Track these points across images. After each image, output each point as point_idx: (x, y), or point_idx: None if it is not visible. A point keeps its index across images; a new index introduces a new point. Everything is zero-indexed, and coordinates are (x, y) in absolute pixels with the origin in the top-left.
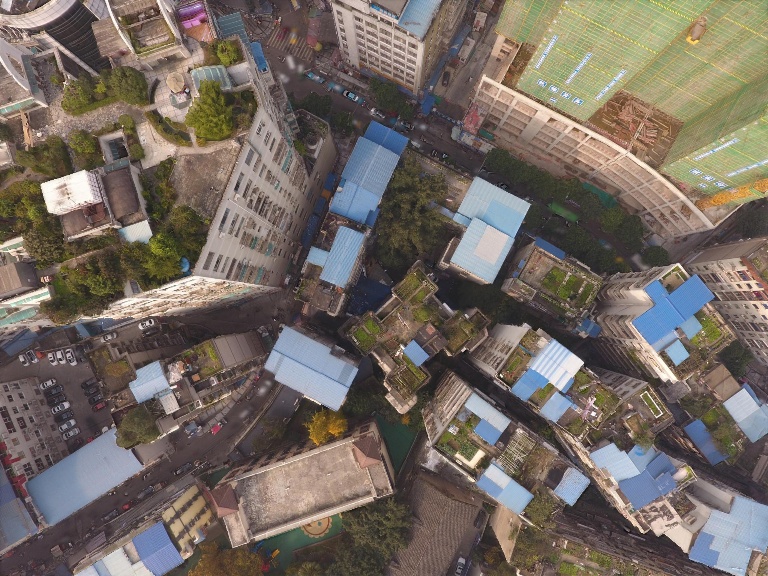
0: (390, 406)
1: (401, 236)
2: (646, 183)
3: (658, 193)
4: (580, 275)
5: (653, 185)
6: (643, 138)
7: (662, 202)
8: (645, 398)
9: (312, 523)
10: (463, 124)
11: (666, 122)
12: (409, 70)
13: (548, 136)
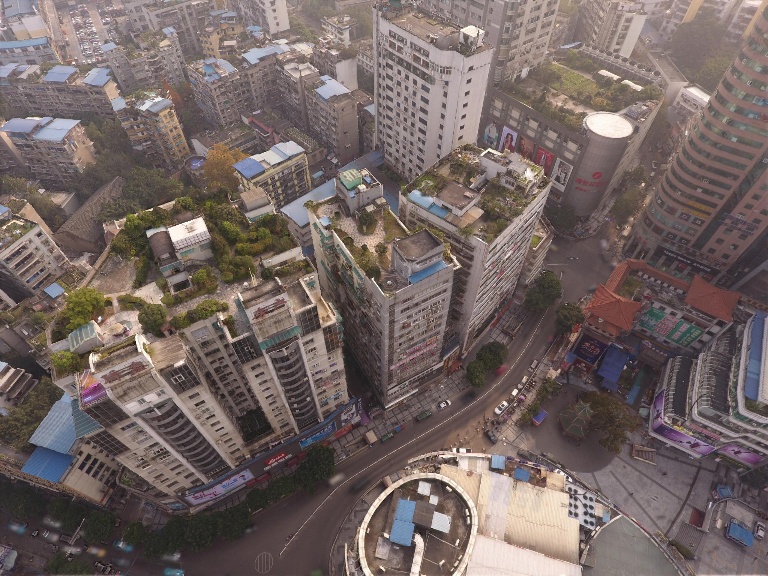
0: None
1: None
2: None
3: None
4: None
5: None
6: None
7: None
8: None
9: None
10: None
11: None
12: None
13: None
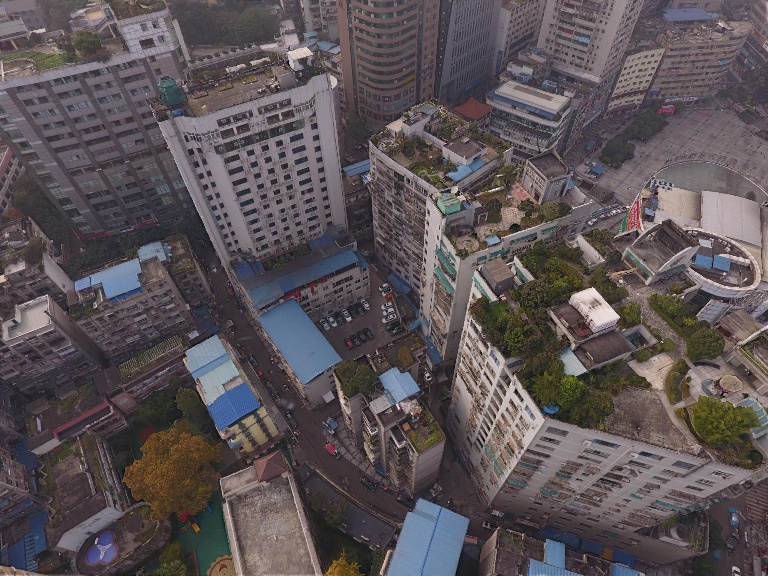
0: None
1: None
2: None
3: None
4: None
5: None
6: None
7: None
8: None
9: (223, 572)
10: None
11: None
12: None
13: None
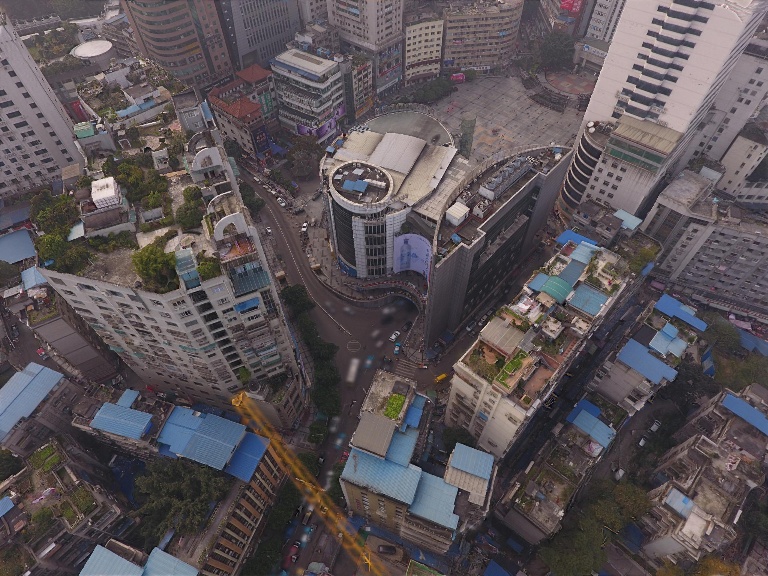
0: None
1: None
2: None
3: None
4: None
5: None
6: None
7: None
8: None
9: None
10: (323, 574)
11: None
12: None
13: None
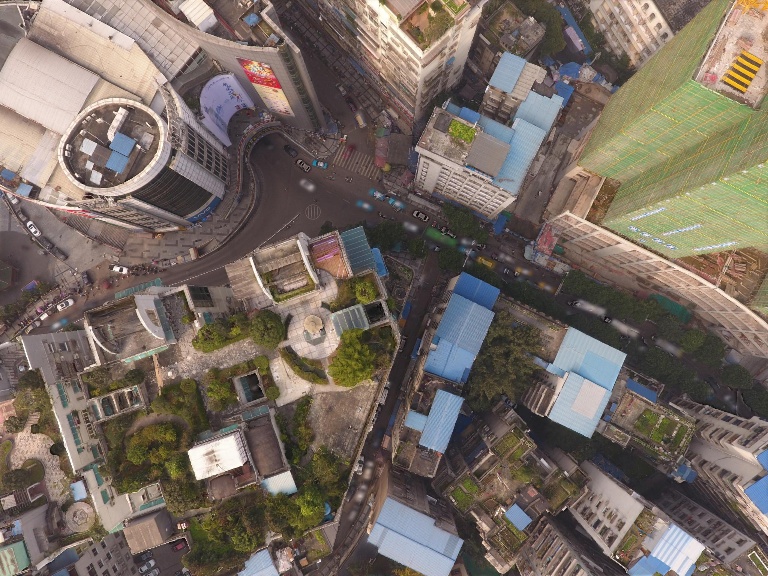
0: (482, 552)
1: (496, 390)
2: (731, 311)
3: (744, 321)
4: (673, 417)
5: (739, 315)
6: (731, 272)
7: (747, 328)
8: (753, 558)
9: None
10: (537, 245)
11: (754, 255)
12: (490, 205)
13: (626, 258)
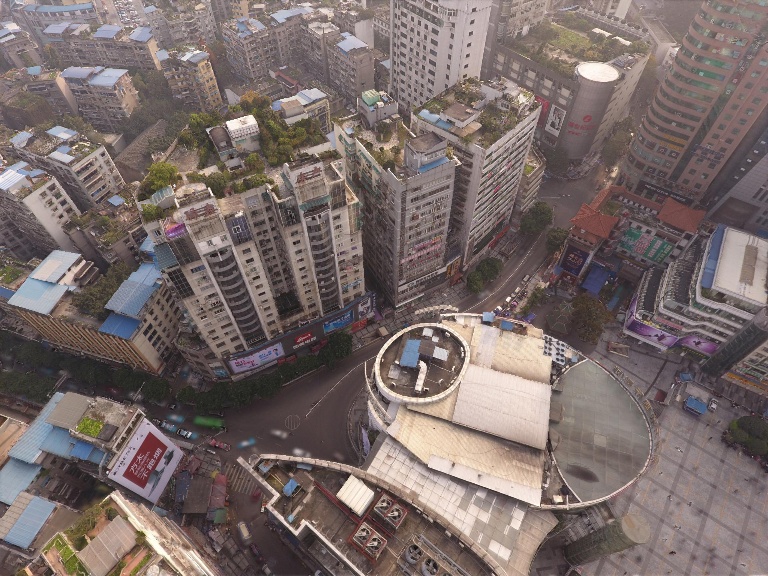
0: None
1: None
2: None
3: None
4: None
5: None
6: None
7: None
8: None
9: None
10: None
11: None
12: None
13: None
